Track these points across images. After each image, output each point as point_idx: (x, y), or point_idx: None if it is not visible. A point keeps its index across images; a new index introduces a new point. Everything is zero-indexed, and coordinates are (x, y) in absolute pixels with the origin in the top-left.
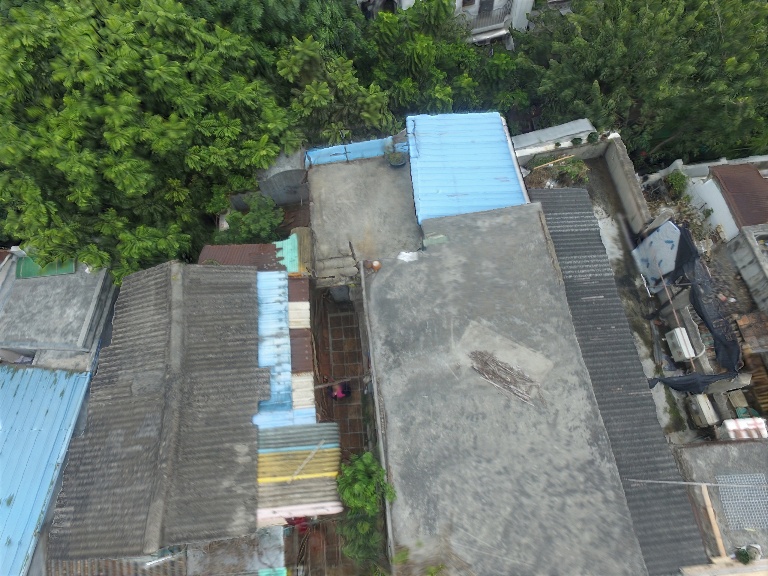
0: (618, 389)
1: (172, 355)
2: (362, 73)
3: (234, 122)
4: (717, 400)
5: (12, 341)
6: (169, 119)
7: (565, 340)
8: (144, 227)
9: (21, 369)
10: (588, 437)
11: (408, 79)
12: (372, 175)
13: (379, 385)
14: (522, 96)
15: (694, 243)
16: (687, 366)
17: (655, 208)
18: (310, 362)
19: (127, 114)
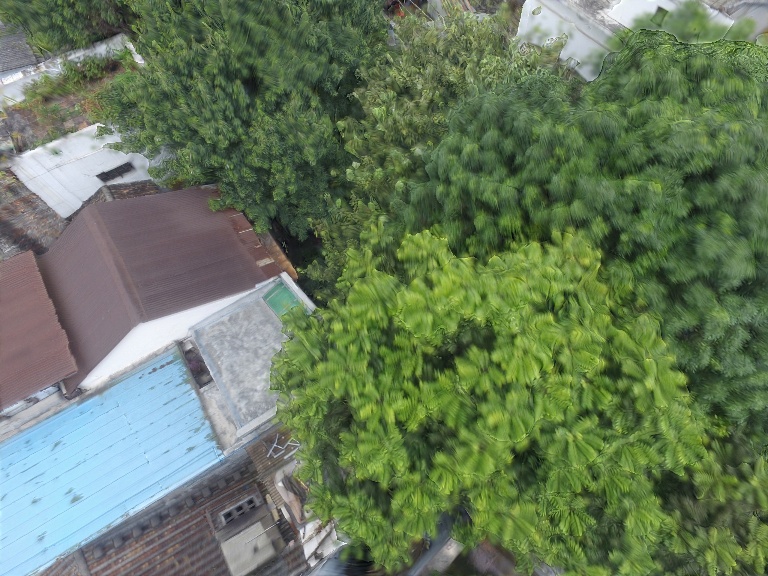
0: None
1: None
2: None
3: (585, 514)
4: None
5: (208, 353)
6: (523, 507)
7: None
8: (376, 514)
9: (190, 385)
10: None
11: None
12: None
13: None
14: None
15: None
16: None
17: None
18: None
19: (485, 475)
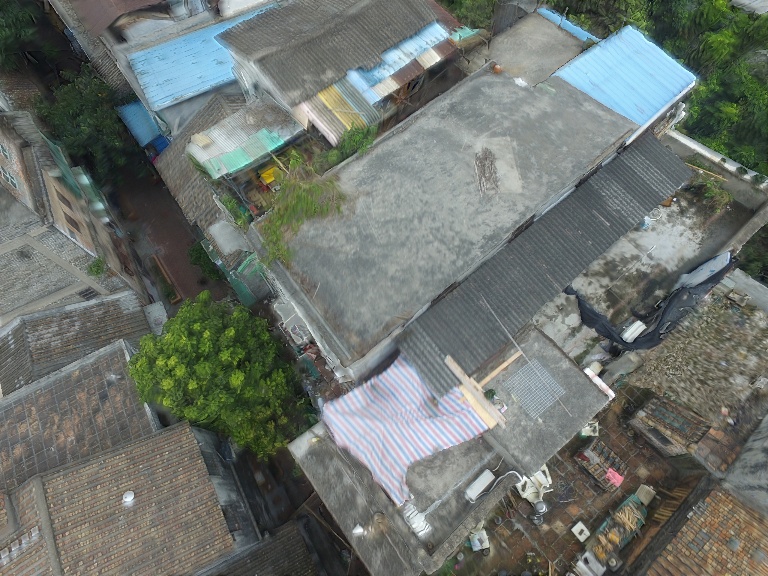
0: (544, 265)
1: (351, 7)
2: (657, 40)
3: None
4: (605, 376)
5: None
6: None
7: (545, 190)
8: None
9: None
10: (488, 234)
11: (681, 59)
12: (563, 45)
13: (421, 115)
14: (767, 171)
15: (725, 274)
16: (617, 353)
17: (761, 319)
18: (404, 82)
19: None
